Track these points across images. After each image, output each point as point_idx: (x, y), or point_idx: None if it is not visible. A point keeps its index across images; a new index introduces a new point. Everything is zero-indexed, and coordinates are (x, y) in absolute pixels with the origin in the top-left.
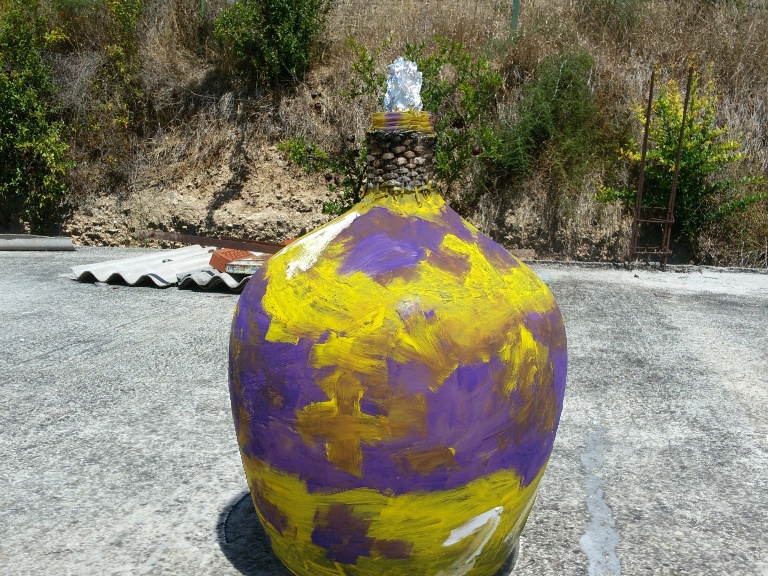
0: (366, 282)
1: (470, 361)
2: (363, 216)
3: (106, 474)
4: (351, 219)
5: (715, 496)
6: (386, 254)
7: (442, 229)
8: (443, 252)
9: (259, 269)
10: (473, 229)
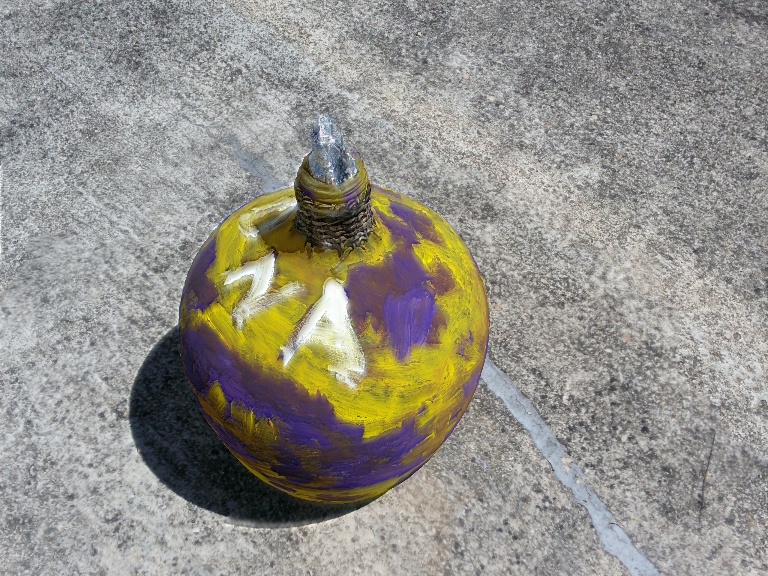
0: (426, 350)
1: (487, 336)
2: (351, 283)
3: None
4: (338, 290)
5: (387, 176)
6: (414, 313)
7: (406, 247)
8: (432, 273)
9: (261, 376)
10: (379, 205)
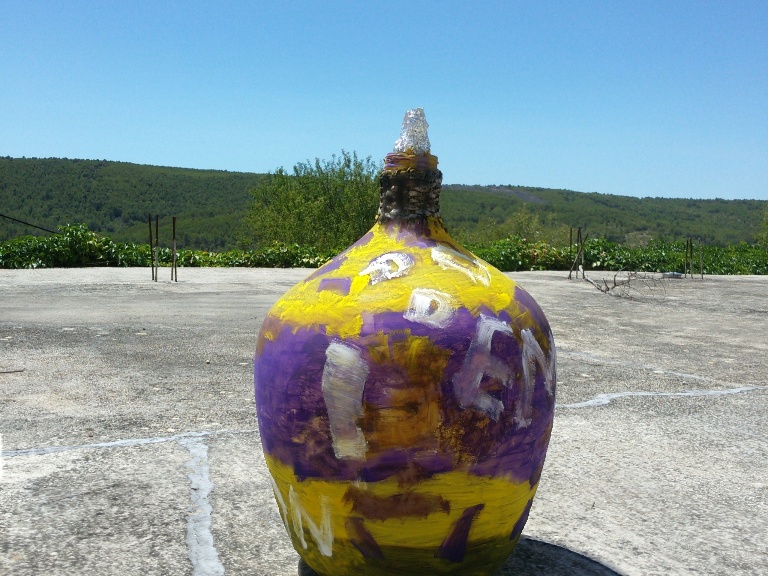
0: None
1: None
2: None
3: (762, 556)
4: None
5: None
6: None
7: None
8: None
9: None
10: None
